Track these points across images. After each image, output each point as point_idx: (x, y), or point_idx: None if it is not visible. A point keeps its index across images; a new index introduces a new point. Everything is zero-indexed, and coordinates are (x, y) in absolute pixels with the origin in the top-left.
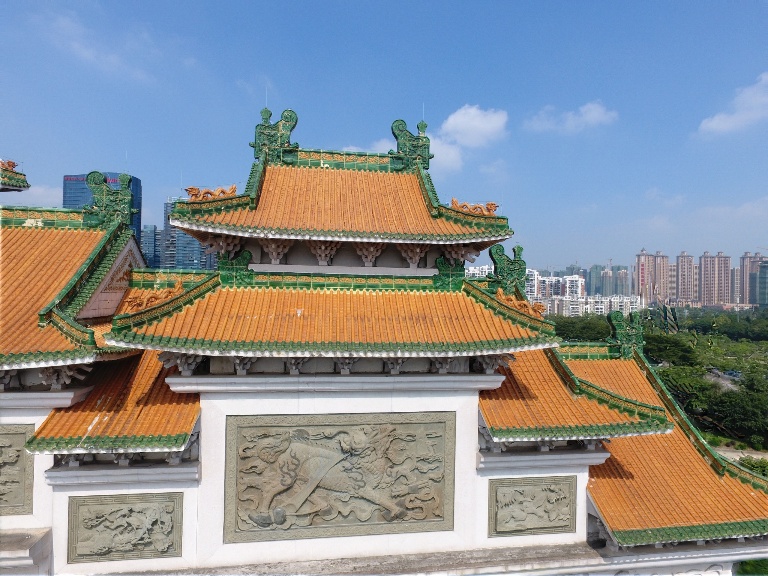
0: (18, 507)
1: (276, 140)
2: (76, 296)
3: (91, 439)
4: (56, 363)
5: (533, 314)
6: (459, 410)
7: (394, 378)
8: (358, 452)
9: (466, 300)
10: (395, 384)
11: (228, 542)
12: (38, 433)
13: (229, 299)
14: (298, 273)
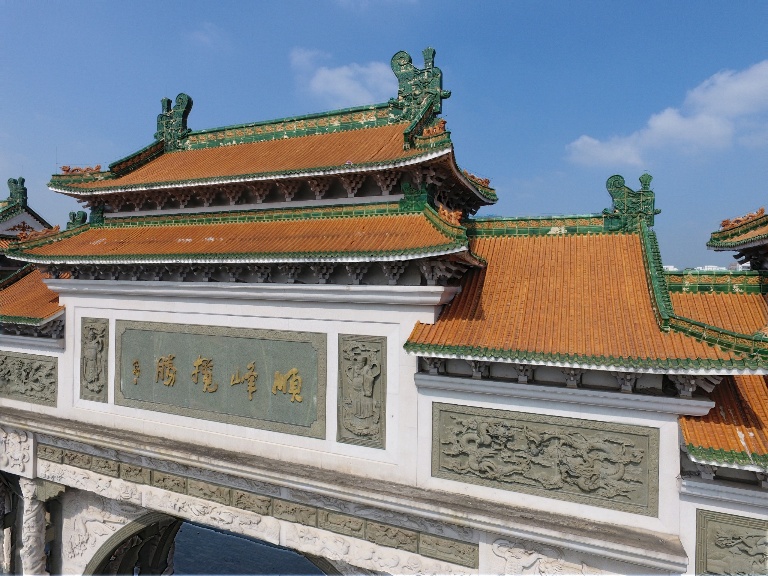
0: (642, 507)
1: None
2: None
3: (760, 457)
4: (729, 372)
5: None
6: None
7: None
8: None
9: None
10: None
11: None
12: (691, 441)
13: None
14: None
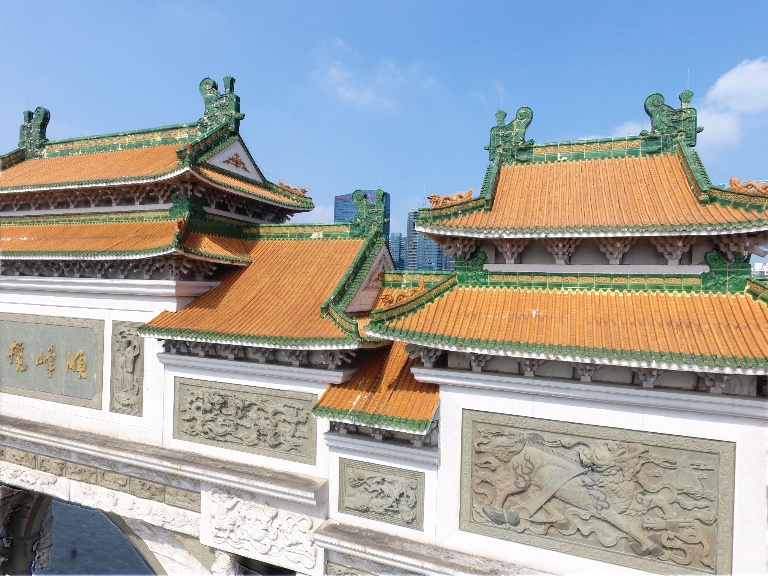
0: (307, 458)
1: (510, 140)
2: (345, 294)
3: (355, 413)
4: (332, 347)
5: None
6: (740, 442)
7: (647, 392)
8: (601, 469)
9: (752, 304)
10: (648, 399)
11: (464, 529)
12: (320, 402)
13: (465, 298)
14: (533, 272)
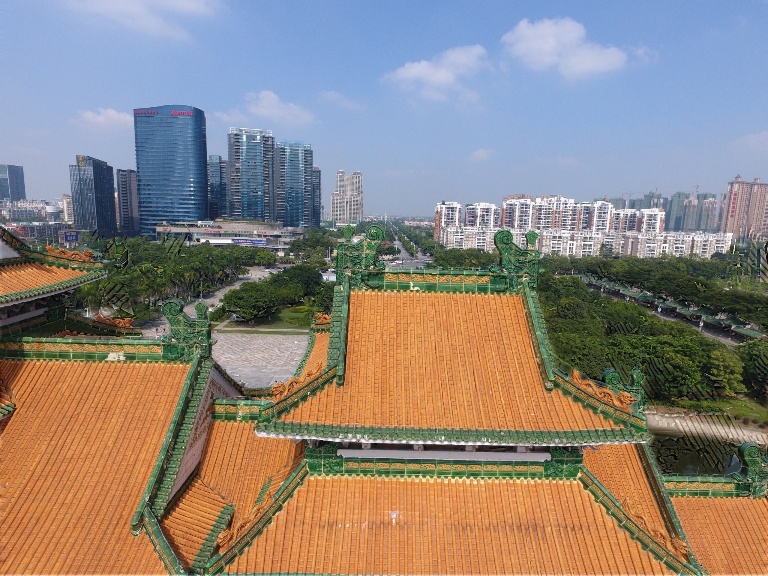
0: None
1: (360, 262)
2: (164, 474)
3: None
4: None
5: (672, 550)
6: None
7: None
8: None
9: (583, 495)
10: None
11: None
12: None
13: (318, 494)
14: (391, 459)
